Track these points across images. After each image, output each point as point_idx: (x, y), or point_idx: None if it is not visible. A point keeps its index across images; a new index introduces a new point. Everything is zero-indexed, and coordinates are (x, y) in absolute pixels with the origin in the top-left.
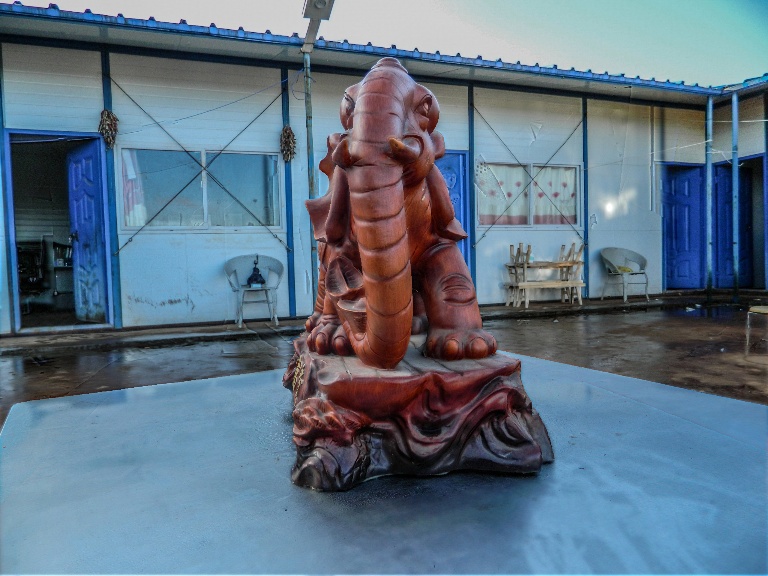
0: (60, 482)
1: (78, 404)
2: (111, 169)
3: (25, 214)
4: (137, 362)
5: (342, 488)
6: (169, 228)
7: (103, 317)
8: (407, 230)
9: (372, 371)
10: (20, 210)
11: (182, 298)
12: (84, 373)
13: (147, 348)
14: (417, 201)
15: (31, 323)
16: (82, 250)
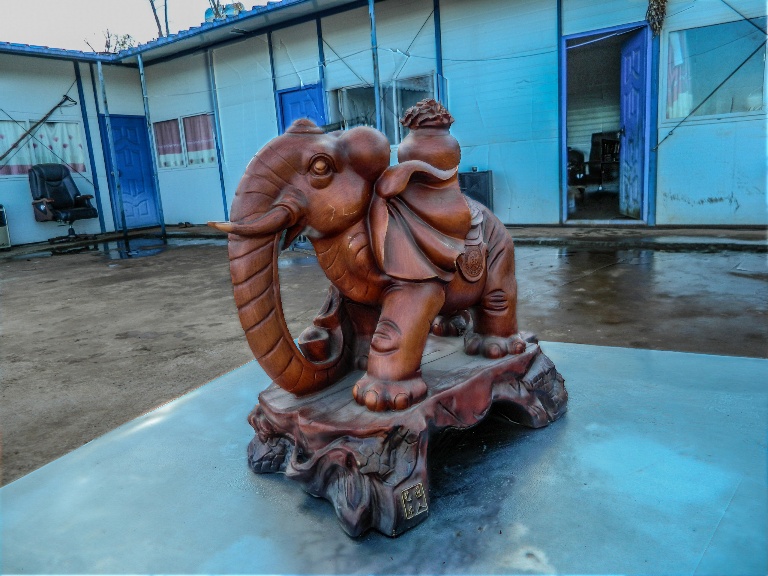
0: (217, 396)
1: None
2: (656, 58)
3: (577, 115)
4: (635, 267)
5: (254, 470)
6: (716, 116)
7: (638, 213)
8: (346, 273)
9: (288, 393)
10: (572, 112)
11: (725, 196)
12: (580, 272)
13: (662, 251)
14: (344, 249)
15: (575, 216)
16: (627, 145)
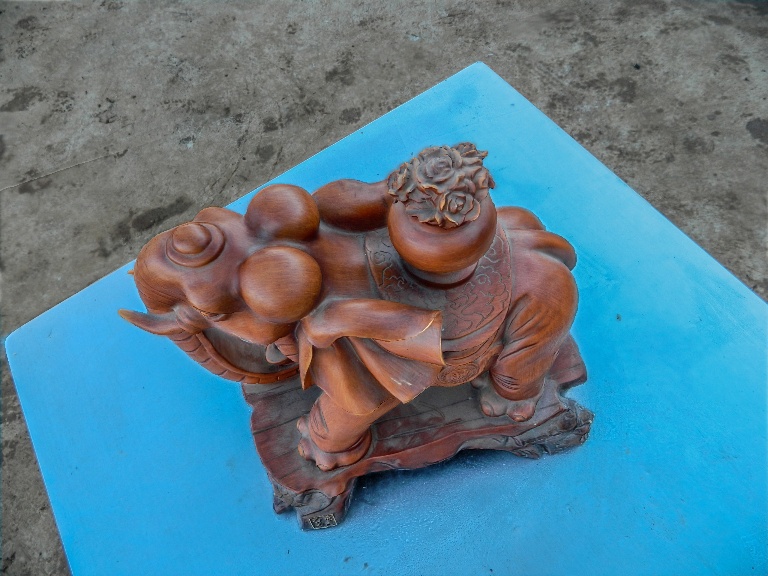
0: None
1: (469, 110)
2: None
3: None
4: None
5: None
6: None
7: None
8: None
9: None
10: None
11: None
12: None
13: None
14: None
15: None
16: None
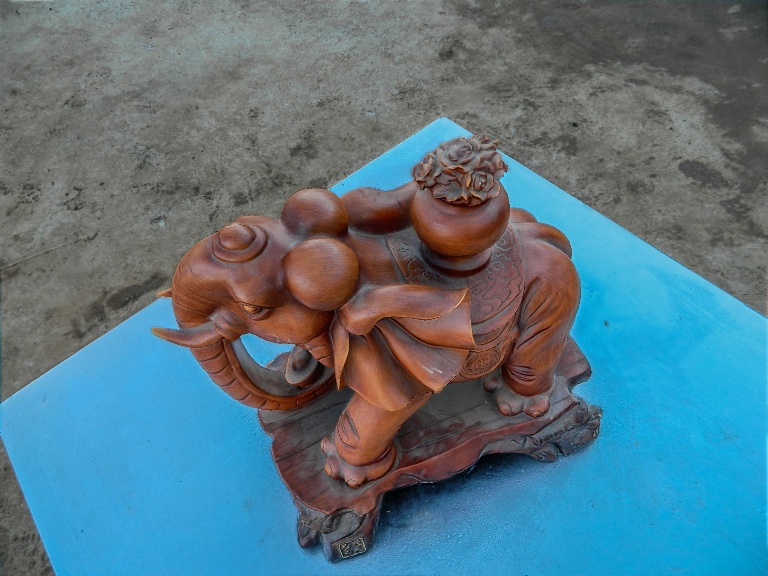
0: None
1: None
2: None
3: None
4: None
5: None
6: None
7: None
8: None
9: None
10: None
11: None
12: None
13: None
14: None
15: None
16: None
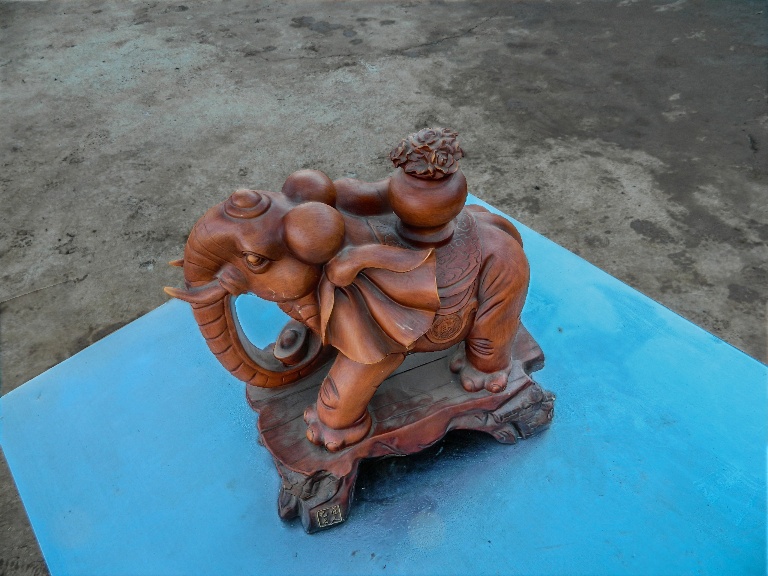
0: None
1: None
2: None
3: None
4: None
5: None
6: None
7: None
8: None
9: None
10: None
11: None
12: None
13: None
14: (296, 310)
15: None
16: None
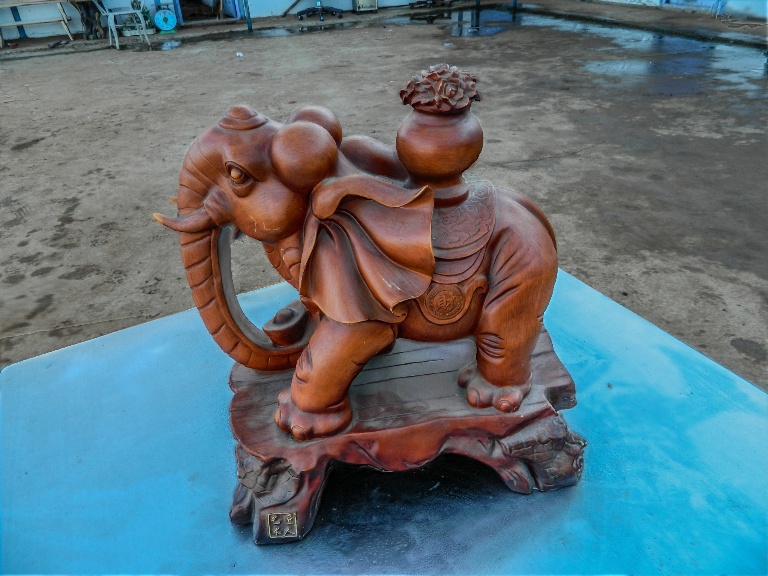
0: None
1: None
2: None
3: None
4: None
5: None
6: None
7: None
8: None
9: None
10: None
11: None
12: None
13: None
14: None
15: None
16: None
